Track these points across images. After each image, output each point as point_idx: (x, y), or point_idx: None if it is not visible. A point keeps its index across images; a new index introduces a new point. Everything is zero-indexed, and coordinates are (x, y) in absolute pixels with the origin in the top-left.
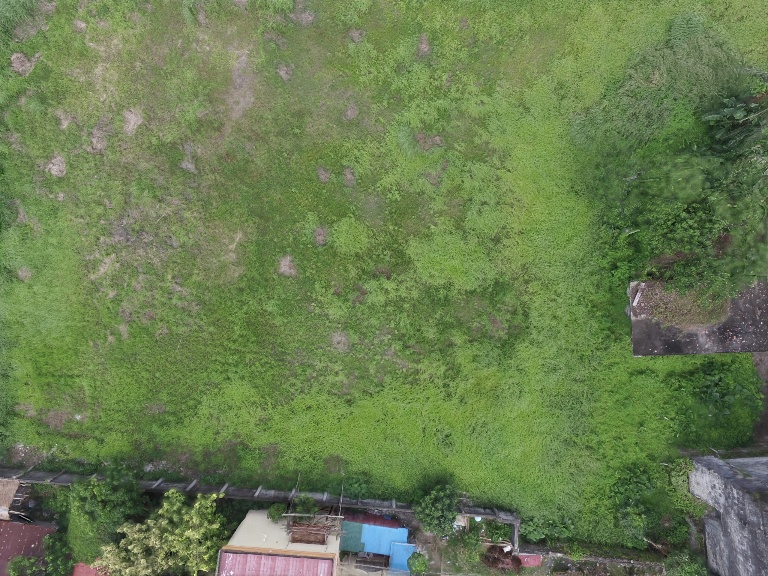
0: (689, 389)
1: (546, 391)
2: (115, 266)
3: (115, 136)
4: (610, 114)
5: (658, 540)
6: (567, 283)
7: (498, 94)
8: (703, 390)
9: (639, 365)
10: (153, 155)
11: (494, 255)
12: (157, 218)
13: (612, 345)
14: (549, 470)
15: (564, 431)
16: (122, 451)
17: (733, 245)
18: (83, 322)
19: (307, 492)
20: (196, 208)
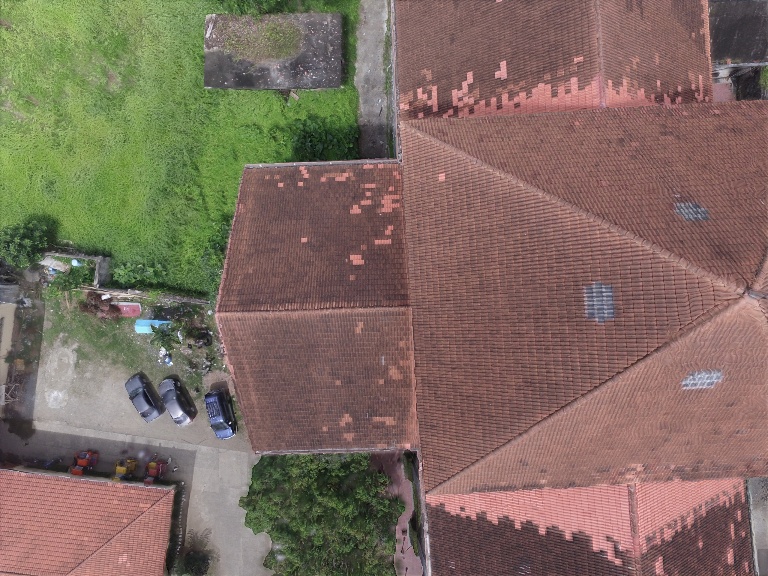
0: (289, 143)
1: (150, 141)
2: None
3: None
4: None
5: None
6: (174, 34)
7: None
8: (296, 140)
9: (246, 121)
10: None
11: (112, 10)
12: None
13: (220, 100)
14: (146, 217)
15: (161, 178)
16: None
17: (336, 0)
18: None
19: None
20: None
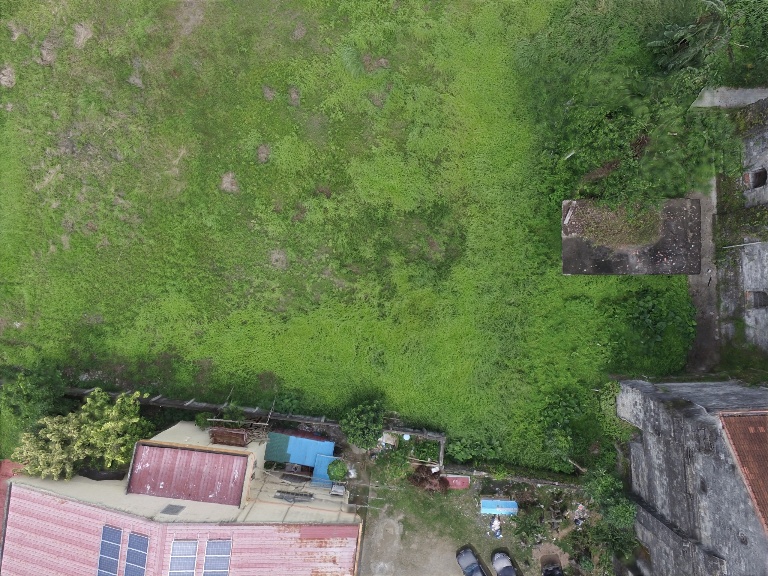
0: (623, 316)
1: (480, 313)
2: (59, 177)
3: (65, 49)
4: (554, 40)
5: (586, 466)
6: (504, 206)
7: (444, 18)
8: (636, 316)
9: (574, 292)
10: (101, 69)
11: (434, 178)
12: (103, 131)
13: (548, 270)
14: (479, 392)
15: (495, 353)
16: (59, 359)
17: (672, 173)
18: (26, 230)
19: (239, 406)
20: (141, 122)
